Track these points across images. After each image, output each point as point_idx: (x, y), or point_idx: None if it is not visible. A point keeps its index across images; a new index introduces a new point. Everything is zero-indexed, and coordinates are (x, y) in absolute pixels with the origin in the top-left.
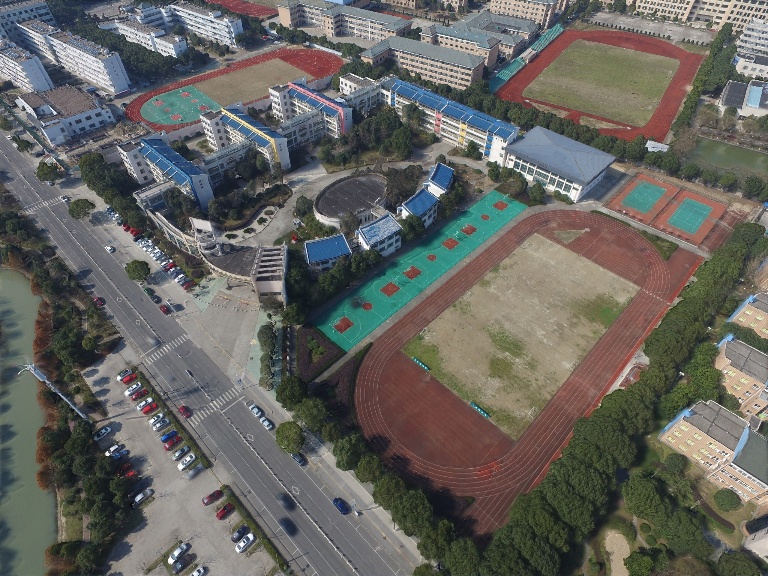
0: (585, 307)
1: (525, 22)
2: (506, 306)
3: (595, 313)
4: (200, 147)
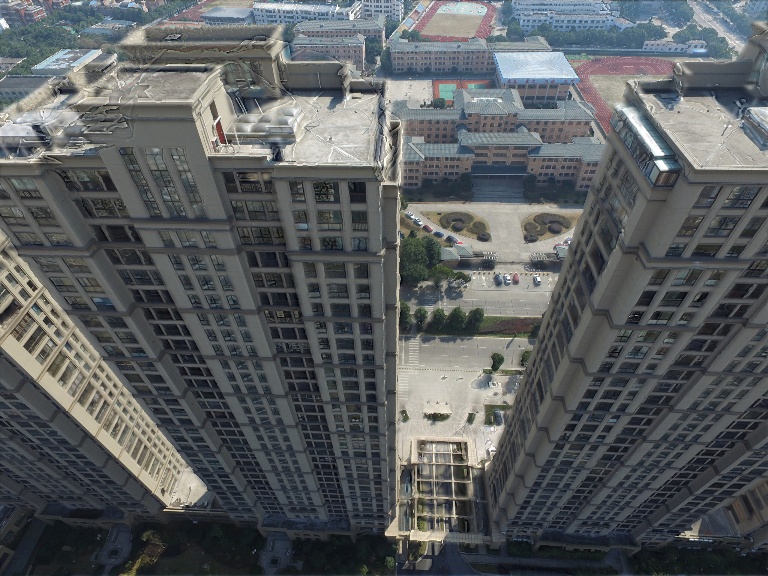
0: None
1: None
2: (245, 0)
3: None
4: (414, 1)
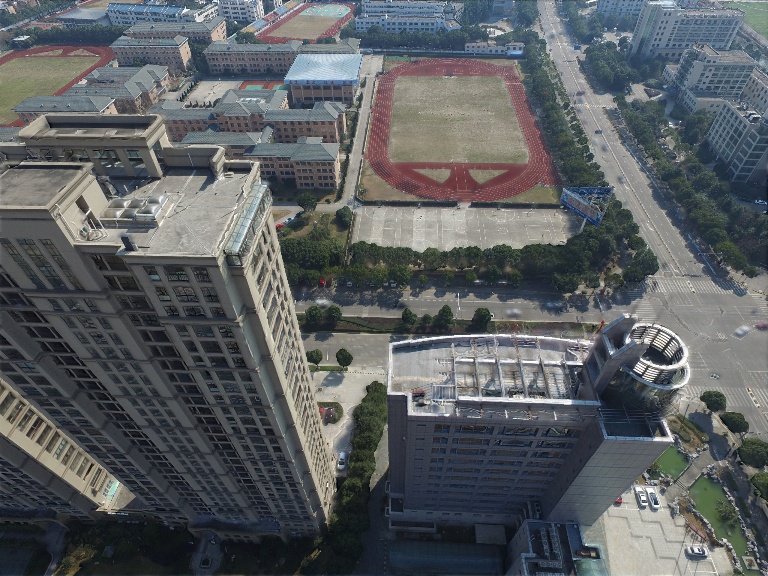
0: (94, 6)
1: (77, 87)
2: None
3: (91, 6)
4: None
